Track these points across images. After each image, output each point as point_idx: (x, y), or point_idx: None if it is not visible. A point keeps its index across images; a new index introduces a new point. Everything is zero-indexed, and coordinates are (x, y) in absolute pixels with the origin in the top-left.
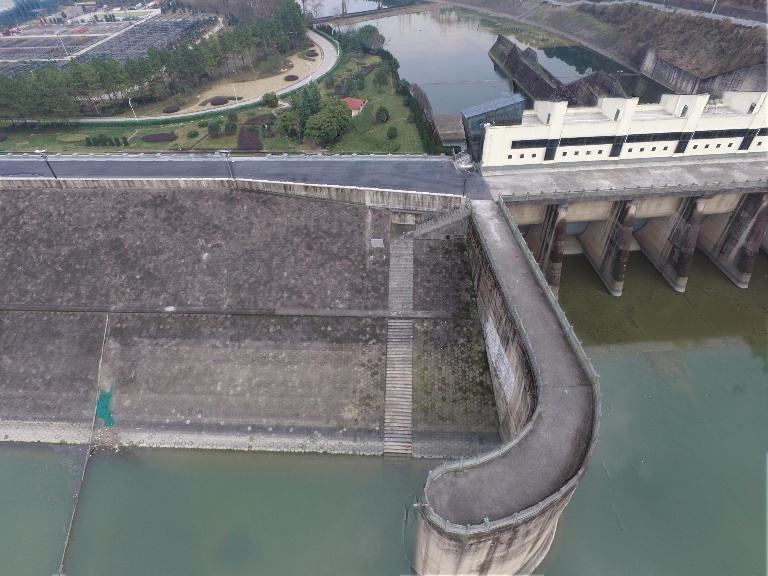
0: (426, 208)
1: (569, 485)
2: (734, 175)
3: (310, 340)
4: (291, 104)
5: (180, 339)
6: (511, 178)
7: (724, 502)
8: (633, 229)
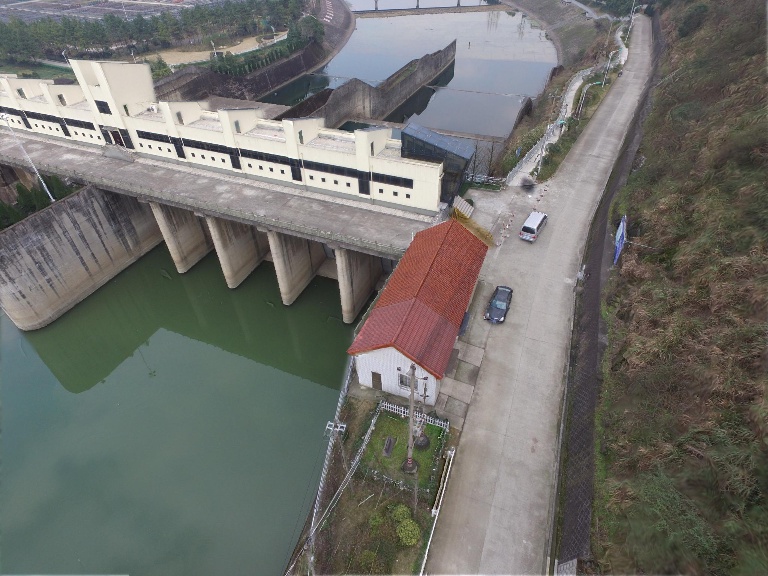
0: None
1: None
2: (32, 153)
3: None
4: None
5: None
6: None
7: None
8: None
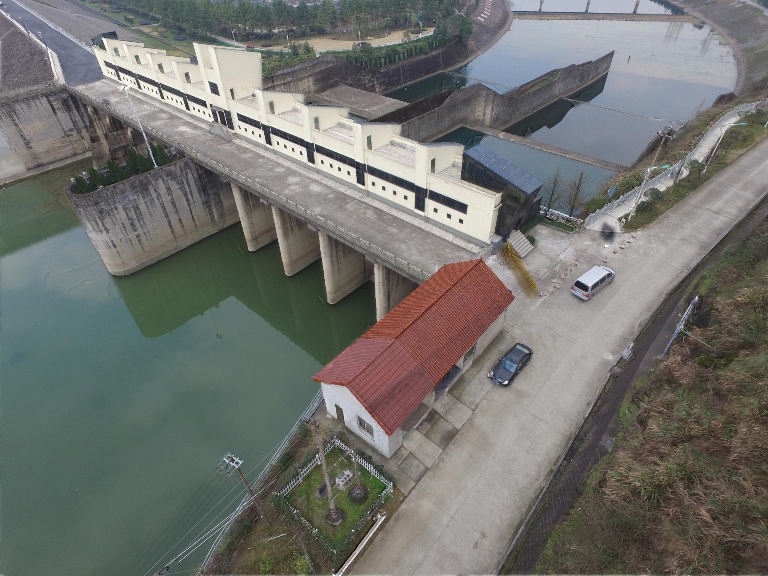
0: None
1: None
2: (158, 121)
3: None
4: None
5: None
6: (104, 85)
7: None
8: None
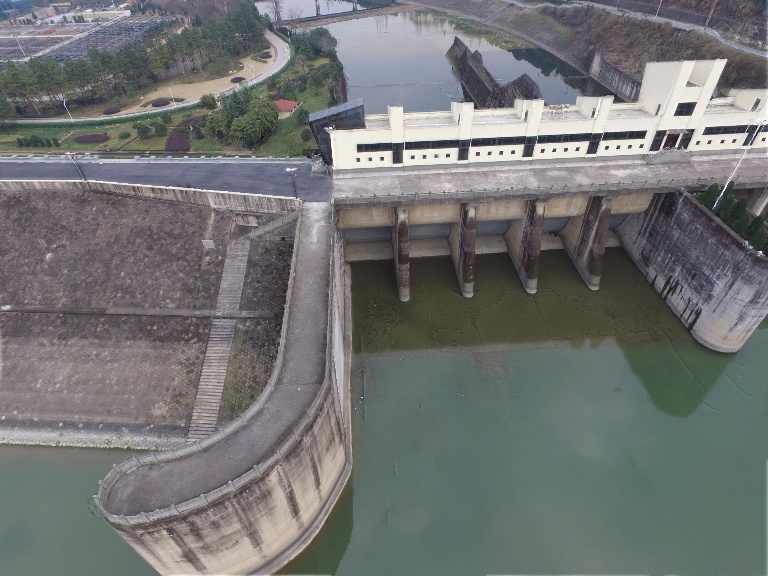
0: (266, 210)
1: (245, 478)
2: (576, 179)
3: (134, 339)
4: (222, 106)
5: (10, 337)
6: (359, 181)
7: (499, 499)
8: (501, 231)
